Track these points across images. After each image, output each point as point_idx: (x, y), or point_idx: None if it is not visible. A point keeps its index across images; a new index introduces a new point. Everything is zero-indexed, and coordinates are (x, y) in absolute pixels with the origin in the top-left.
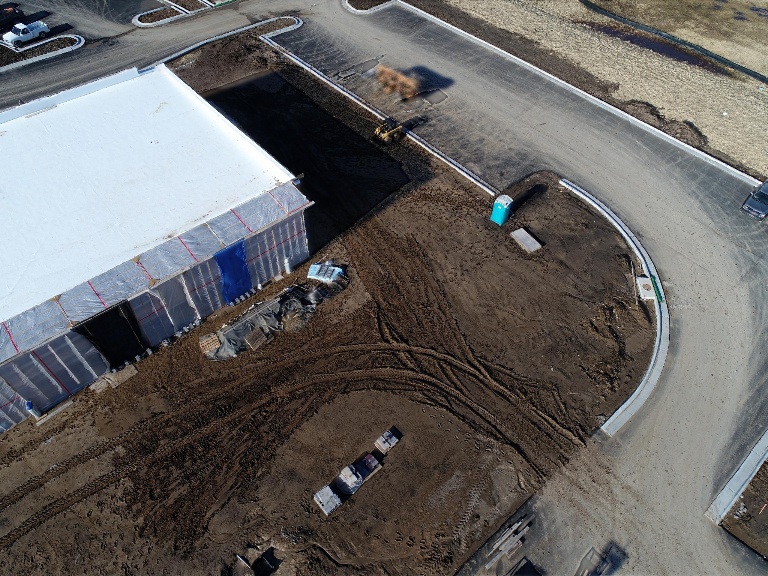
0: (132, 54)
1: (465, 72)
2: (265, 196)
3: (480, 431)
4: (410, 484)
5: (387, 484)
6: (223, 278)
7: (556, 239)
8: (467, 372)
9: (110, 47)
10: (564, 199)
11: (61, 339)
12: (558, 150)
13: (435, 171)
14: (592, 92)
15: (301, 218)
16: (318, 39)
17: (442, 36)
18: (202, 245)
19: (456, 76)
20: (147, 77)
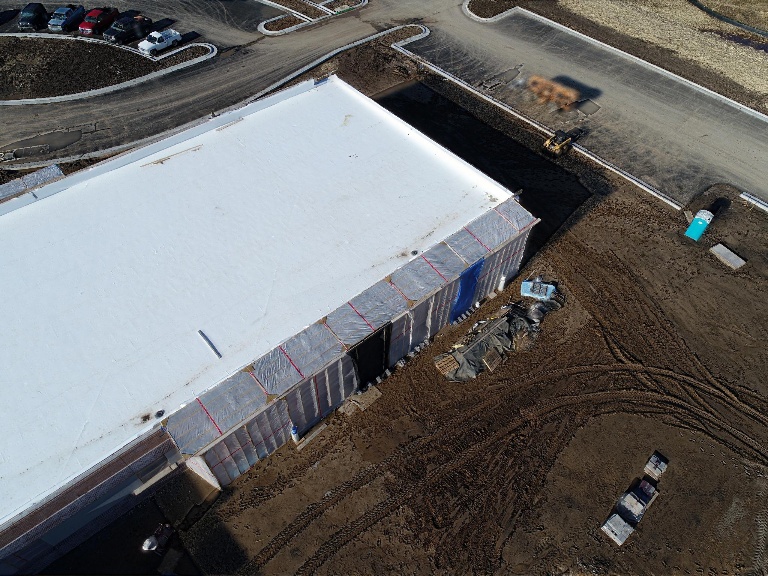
0: (269, 63)
1: (610, 82)
2: (492, 213)
3: (745, 456)
4: (692, 512)
5: (669, 512)
6: (458, 297)
7: (757, 255)
8: (712, 394)
9: (244, 56)
10: (751, 213)
11: (336, 363)
12: (729, 163)
13: (613, 184)
14: (746, 103)
15: (526, 235)
16: (450, 48)
17: (575, 45)
18: (447, 264)
19: (602, 86)
20: (322, 89)
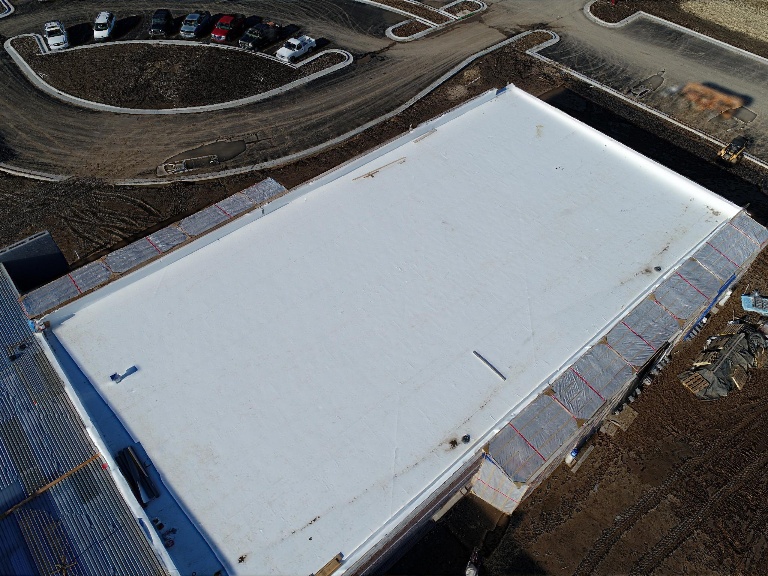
0: (409, 70)
1: (758, 88)
2: (729, 228)
3: None
4: None
5: None
6: (704, 314)
7: None
8: None
9: (382, 62)
10: None
11: None
12: None
13: None
14: None
15: None
16: (586, 54)
17: (711, 50)
18: (703, 281)
19: (752, 93)
20: (503, 98)
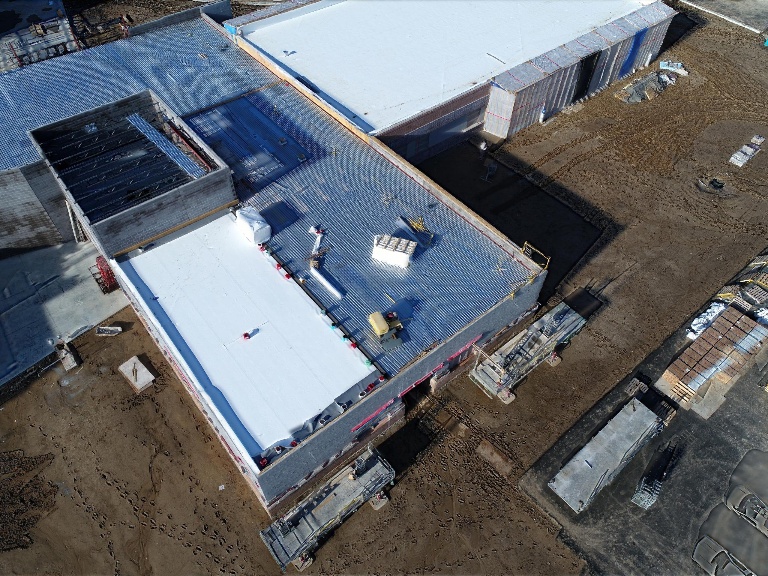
0: None
1: None
2: (649, 7)
3: None
4: None
5: (767, 157)
6: (629, 54)
7: None
8: None
9: None
10: None
11: (574, 66)
12: None
13: (711, 19)
14: None
15: (669, 23)
16: None
17: None
18: (627, 28)
19: None
20: None
